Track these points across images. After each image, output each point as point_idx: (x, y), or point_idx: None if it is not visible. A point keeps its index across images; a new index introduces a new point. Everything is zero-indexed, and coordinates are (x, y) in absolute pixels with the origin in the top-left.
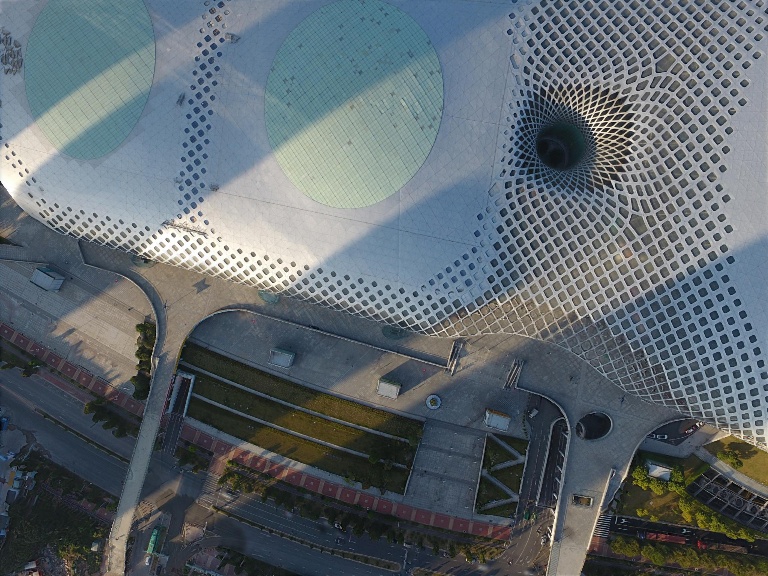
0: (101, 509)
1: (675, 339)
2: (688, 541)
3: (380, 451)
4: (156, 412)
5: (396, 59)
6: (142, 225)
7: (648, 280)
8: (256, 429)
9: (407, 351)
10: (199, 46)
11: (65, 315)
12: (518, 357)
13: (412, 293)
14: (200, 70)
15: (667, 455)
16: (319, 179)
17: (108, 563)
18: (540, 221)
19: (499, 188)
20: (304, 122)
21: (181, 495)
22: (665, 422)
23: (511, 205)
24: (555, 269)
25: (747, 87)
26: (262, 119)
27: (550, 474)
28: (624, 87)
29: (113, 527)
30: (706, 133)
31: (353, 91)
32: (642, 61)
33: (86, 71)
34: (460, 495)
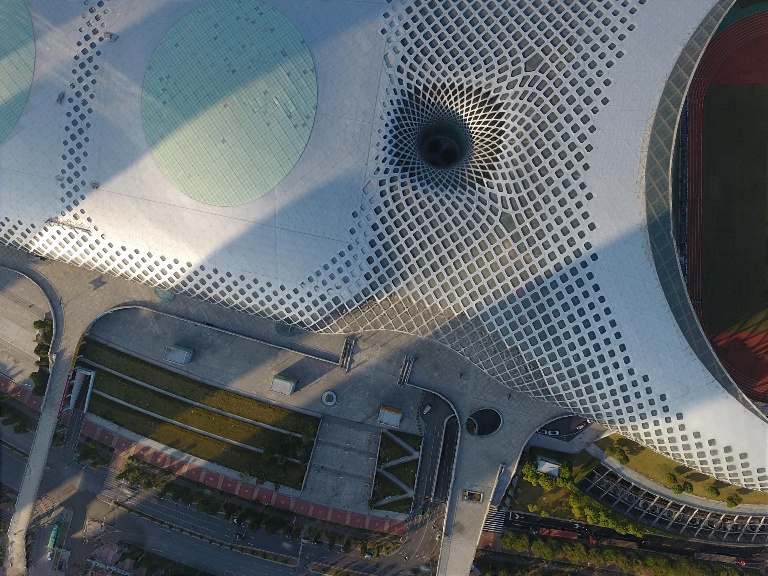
0: (4, 504)
1: (546, 336)
2: (581, 536)
3: (278, 447)
4: (54, 408)
5: (269, 58)
6: (28, 222)
7: (518, 277)
8: (156, 425)
9: (300, 348)
10: (78, 45)
11: None
12: (409, 354)
13: (292, 290)
14: (79, 69)
15: (558, 451)
16: (195, 177)
17: (10, 558)
18: (414, 219)
19: (373, 186)
20: (179, 120)
21: (83, 491)
22: (553, 418)
23: (385, 203)
24: (430, 266)
25: (609, 86)
26: (139, 117)
27: (446, 470)
28: (495, 86)
29: (12, 522)
30: (571, 132)
31: (226, 90)
32: (512, 60)
33: None
34: (357, 491)
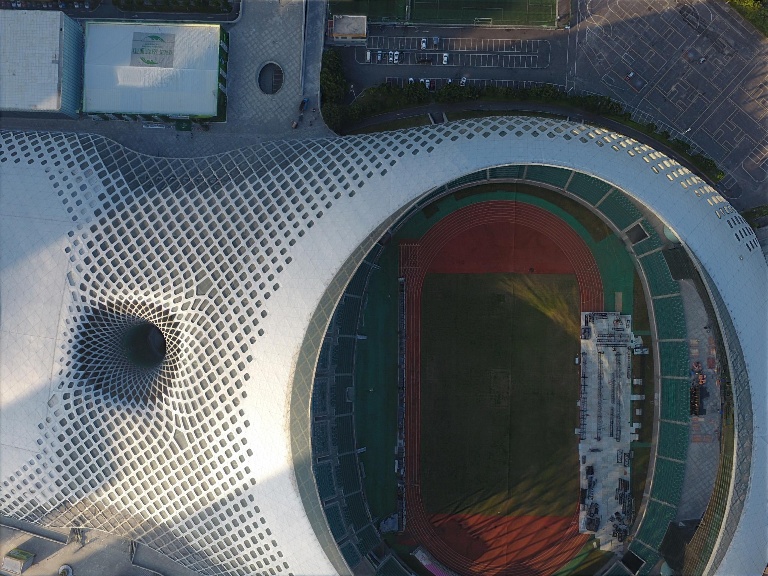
0: None
1: (225, 546)
2: None
3: None
4: None
5: None
6: None
7: (193, 492)
8: None
9: (30, 527)
10: None
11: None
12: (134, 535)
13: None
14: None
15: None
16: None
17: None
18: (97, 431)
19: (58, 399)
20: None
21: None
22: None
23: (70, 415)
24: (115, 476)
25: (265, 318)
26: None
27: None
28: (172, 306)
29: None
30: (232, 359)
31: None
32: (186, 283)
33: None
34: None
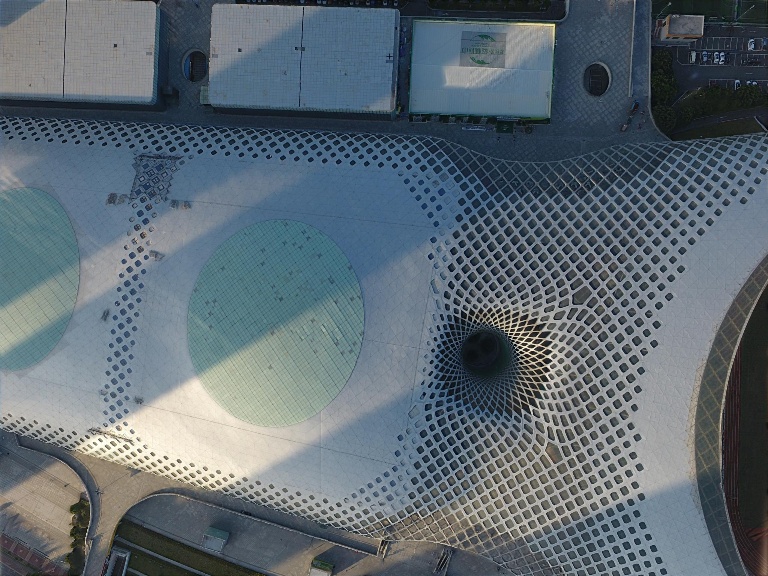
0: None
1: (591, 561)
2: None
3: None
4: None
5: (317, 285)
6: (69, 430)
7: (564, 506)
8: None
9: (338, 538)
10: (123, 263)
11: (2, 489)
12: (447, 547)
13: (335, 504)
14: (124, 287)
15: None
16: (241, 399)
17: None
18: (459, 443)
19: (419, 410)
20: (225, 345)
21: None
22: None
23: (431, 427)
24: (474, 489)
25: (659, 329)
26: (185, 338)
27: None
28: (542, 315)
29: None
30: (619, 371)
31: (273, 318)
32: (560, 291)
33: (10, 287)
34: None
